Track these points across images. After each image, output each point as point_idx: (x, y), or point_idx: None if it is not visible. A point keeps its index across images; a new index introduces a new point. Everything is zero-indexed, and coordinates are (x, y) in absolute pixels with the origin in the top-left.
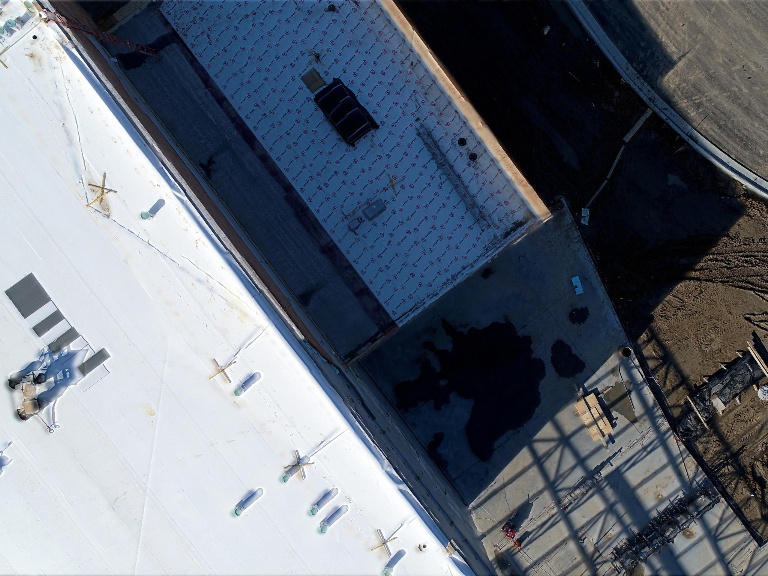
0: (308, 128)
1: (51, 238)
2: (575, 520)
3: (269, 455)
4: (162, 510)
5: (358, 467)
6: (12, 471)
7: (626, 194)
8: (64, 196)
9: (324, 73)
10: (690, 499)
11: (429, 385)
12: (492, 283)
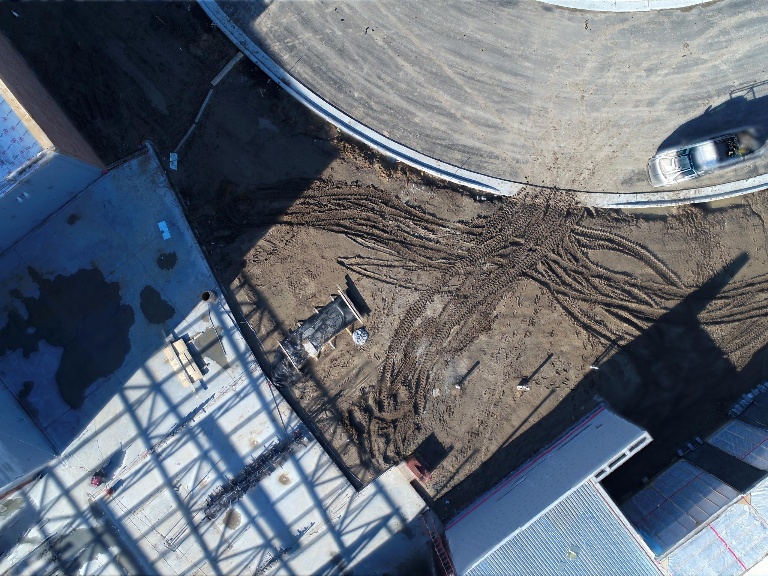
0: None
1: None
2: (169, 467)
3: None
4: None
5: None
6: None
7: (215, 138)
8: None
9: None
10: (285, 445)
11: (18, 333)
12: (78, 229)
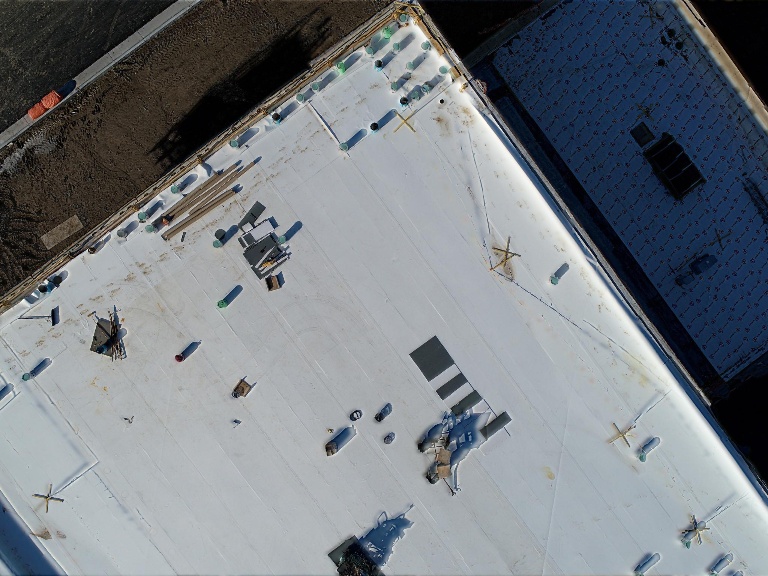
0: (636, 182)
1: (455, 301)
2: None
3: (666, 520)
4: (560, 574)
5: (755, 533)
6: (413, 534)
7: None
8: (468, 259)
9: (653, 127)
10: None
11: None
12: None
